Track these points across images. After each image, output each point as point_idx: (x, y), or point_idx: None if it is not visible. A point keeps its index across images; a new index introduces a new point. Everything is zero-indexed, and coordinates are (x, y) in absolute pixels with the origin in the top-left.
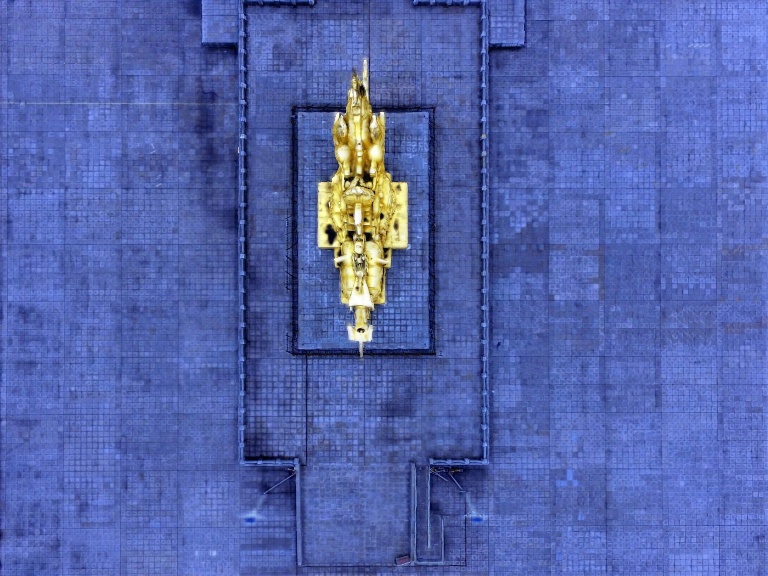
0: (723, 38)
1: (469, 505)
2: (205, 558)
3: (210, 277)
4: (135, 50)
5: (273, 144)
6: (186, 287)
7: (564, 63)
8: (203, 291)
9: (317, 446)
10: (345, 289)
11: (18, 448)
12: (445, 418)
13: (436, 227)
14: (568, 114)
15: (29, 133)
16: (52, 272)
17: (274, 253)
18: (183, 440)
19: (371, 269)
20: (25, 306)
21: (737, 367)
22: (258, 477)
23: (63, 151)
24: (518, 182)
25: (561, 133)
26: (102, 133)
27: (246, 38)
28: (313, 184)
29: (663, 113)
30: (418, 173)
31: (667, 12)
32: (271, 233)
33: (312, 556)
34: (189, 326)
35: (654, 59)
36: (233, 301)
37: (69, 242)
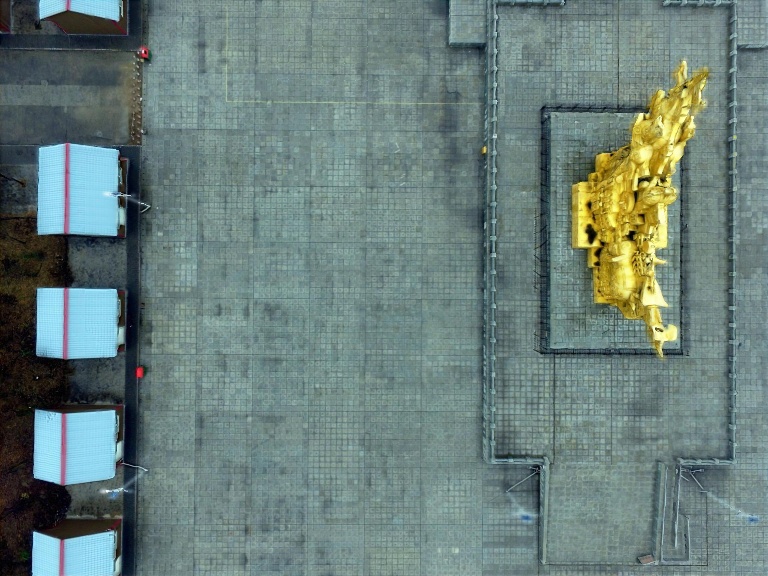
0: None
1: (710, 505)
2: (448, 555)
3: (453, 276)
4: (381, 50)
5: (522, 144)
6: (429, 285)
7: None
8: (446, 290)
9: (564, 445)
10: (620, 288)
11: (263, 444)
12: (692, 418)
13: None
14: None
15: (276, 132)
16: (297, 270)
17: (522, 252)
18: (426, 438)
19: None
20: (271, 303)
21: None
22: (500, 475)
23: (309, 150)
24: (760, 183)
25: None
26: (347, 132)
27: (497, 38)
28: (566, 184)
29: None
30: None
31: None
32: (519, 232)
33: (554, 554)
34: (432, 324)
35: None
36: (476, 300)
37: (314, 240)
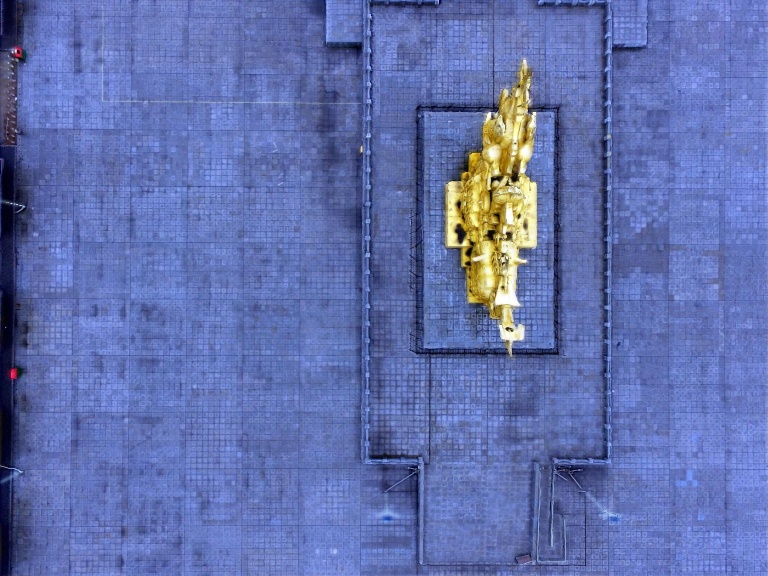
0: None
1: (589, 504)
2: (326, 556)
3: (331, 276)
4: (258, 49)
5: (397, 143)
6: (307, 286)
7: (685, 64)
8: (324, 290)
9: (440, 445)
10: (482, 288)
11: (140, 445)
12: (568, 417)
13: (559, 227)
14: (688, 114)
15: (152, 132)
16: (174, 270)
17: (398, 252)
18: (304, 438)
19: (510, 268)
20: (148, 304)
21: None
22: (379, 475)
23: (186, 150)
24: (638, 182)
25: (681, 133)
26: (224, 132)
27: (371, 38)
28: (439, 183)
29: None
30: (544, 173)
31: None
32: (395, 232)
33: (433, 555)
34: (310, 325)
35: None
36: (354, 300)
37: (191, 240)
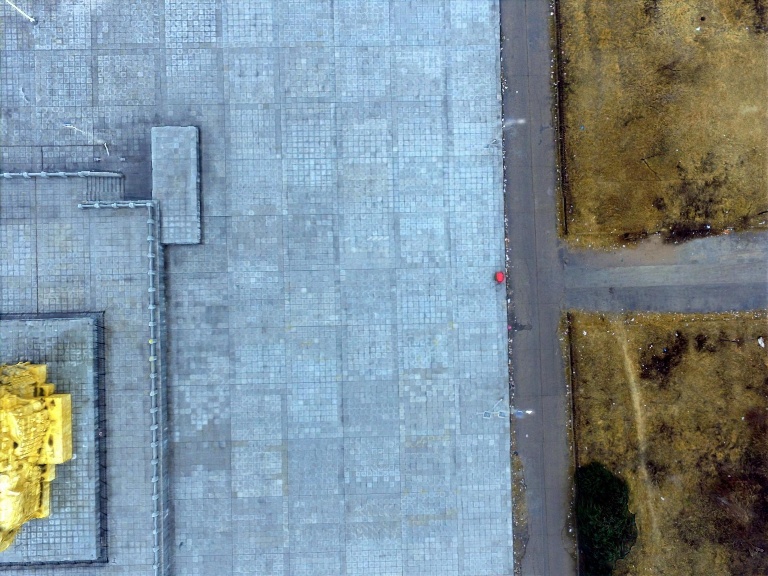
0: (401, 231)
1: None
2: None
3: None
4: None
5: None
6: None
7: (243, 259)
8: None
9: None
10: None
11: None
12: None
13: (107, 432)
14: (248, 310)
15: None
16: None
17: None
18: None
19: None
20: None
21: (422, 560)
22: None
23: None
24: (198, 379)
25: (241, 329)
26: None
27: None
28: None
29: (343, 306)
30: (83, 381)
31: (345, 206)
32: None
33: None
34: None
35: (333, 253)
36: None
37: None
